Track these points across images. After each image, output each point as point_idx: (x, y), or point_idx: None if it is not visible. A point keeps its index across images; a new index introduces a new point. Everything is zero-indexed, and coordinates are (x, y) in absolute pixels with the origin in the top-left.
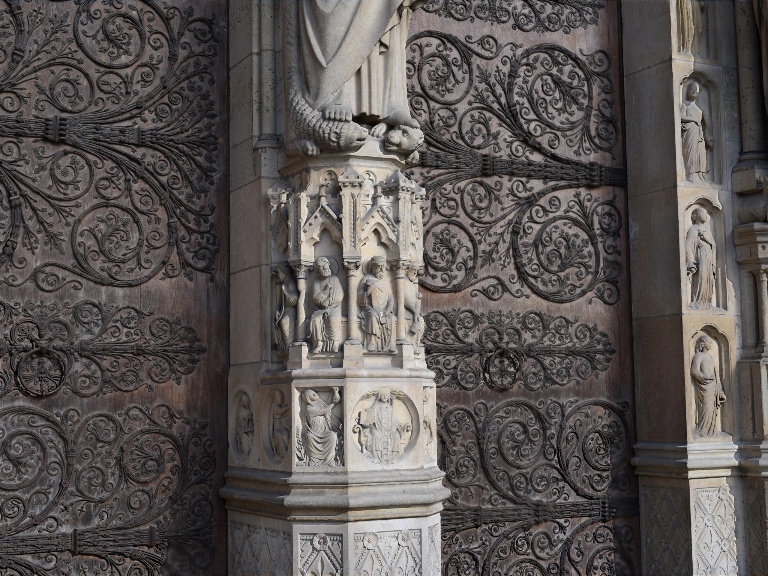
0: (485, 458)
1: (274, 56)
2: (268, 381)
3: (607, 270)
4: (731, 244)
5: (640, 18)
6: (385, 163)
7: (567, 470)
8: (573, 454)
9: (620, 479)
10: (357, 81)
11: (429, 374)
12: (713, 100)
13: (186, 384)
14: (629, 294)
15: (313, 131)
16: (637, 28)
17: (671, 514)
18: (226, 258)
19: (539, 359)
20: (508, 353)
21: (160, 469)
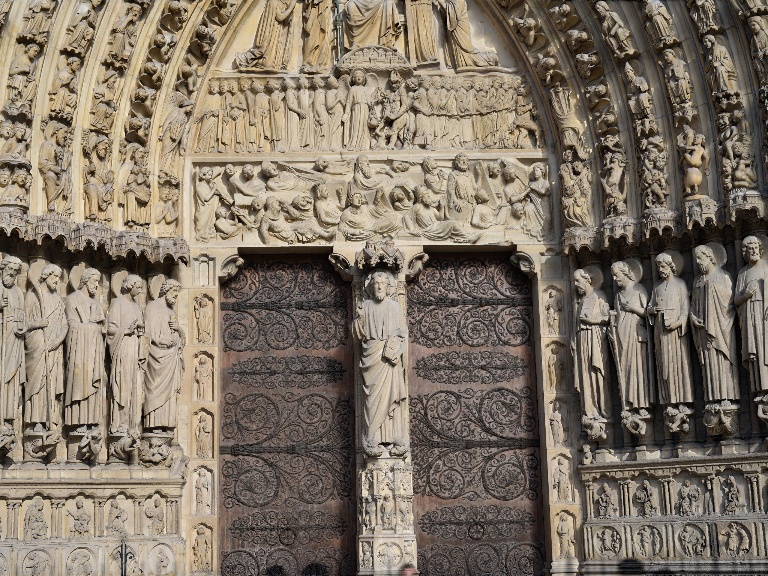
0: (469, 568)
1: None
2: None
3: (531, 485)
4: (577, 473)
5: None
6: (393, 459)
7: (510, 573)
8: (514, 567)
9: None
10: (381, 431)
11: (410, 536)
12: (568, 409)
13: (341, 539)
14: (542, 495)
15: None
16: (538, 377)
17: None
18: (355, 491)
19: (496, 525)
20: (480, 523)
21: (331, 571)
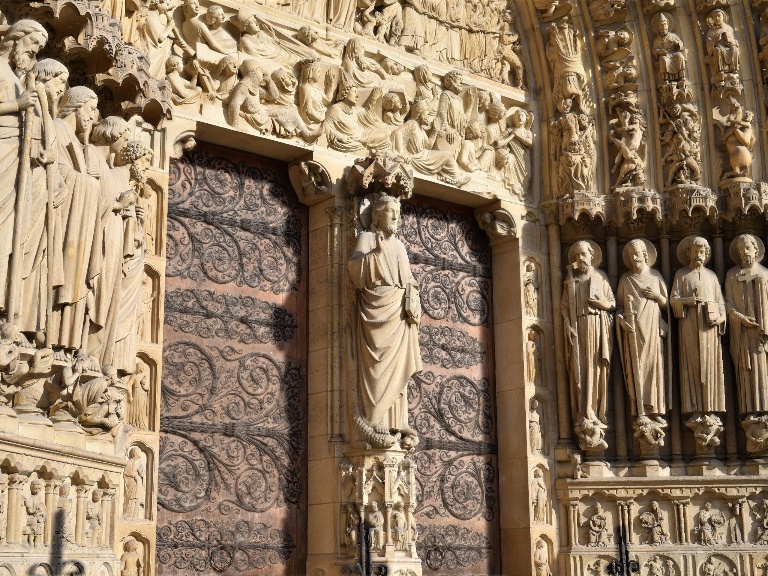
0: None
1: (340, 393)
2: (341, 564)
3: (488, 501)
4: (554, 489)
5: (506, 362)
6: (401, 453)
7: None
8: None
9: None
10: (389, 412)
11: None
12: (545, 409)
13: (286, 565)
14: (499, 515)
15: (370, 438)
16: (504, 367)
17: None
18: (305, 496)
19: (454, 552)
20: (439, 548)
21: None
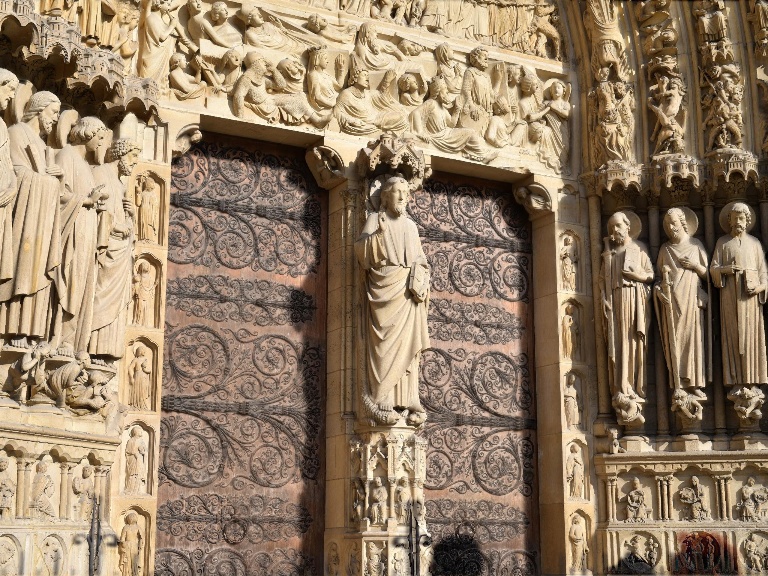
0: None
1: (352, 372)
2: (349, 537)
3: (525, 477)
4: (593, 464)
5: (544, 337)
6: (408, 430)
7: None
8: None
9: None
10: (395, 390)
11: (428, 535)
12: (583, 384)
13: (303, 538)
14: (538, 490)
15: (374, 415)
16: (542, 342)
17: None
18: (324, 472)
19: (487, 527)
20: (470, 523)
21: None
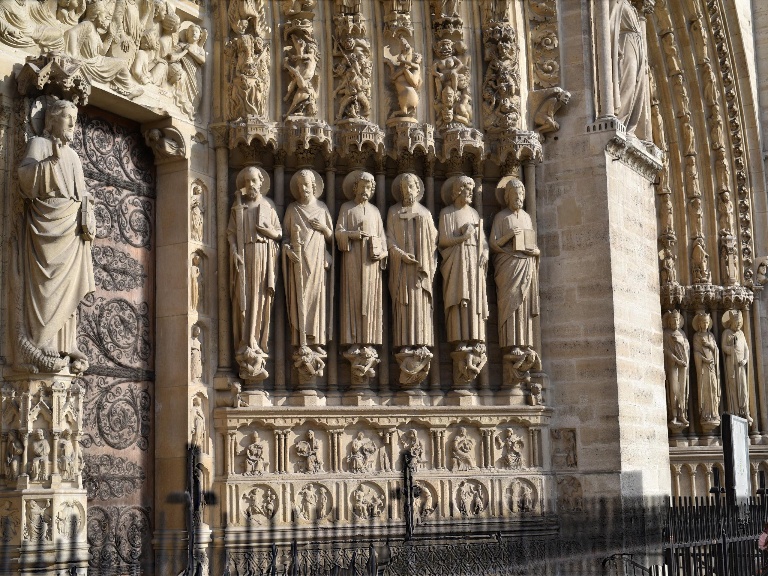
0: None
1: (1, 312)
2: None
3: (143, 430)
4: (212, 418)
5: (168, 287)
6: (70, 378)
7: (120, 547)
8: (123, 538)
9: (145, 552)
10: (59, 334)
11: None
12: (206, 337)
13: None
14: (154, 444)
15: (38, 361)
16: (166, 292)
17: (176, 570)
18: None
19: (108, 482)
20: (93, 479)
21: None
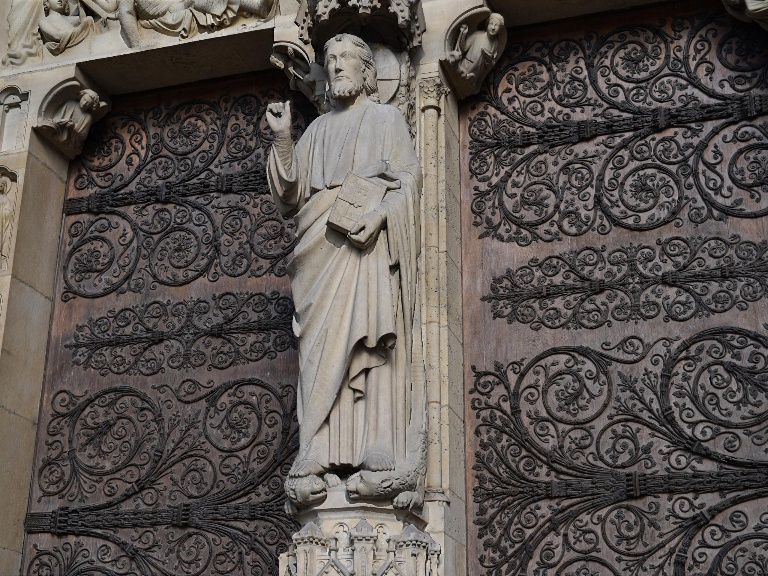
0: None
1: None
2: None
3: None
4: None
5: None
6: (357, 512)
7: None
8: None
9: None
10: None
11: None
12: None
13: None
14: None
15: None
16: None
17: None
18: None
19: None
20: None
21: None
